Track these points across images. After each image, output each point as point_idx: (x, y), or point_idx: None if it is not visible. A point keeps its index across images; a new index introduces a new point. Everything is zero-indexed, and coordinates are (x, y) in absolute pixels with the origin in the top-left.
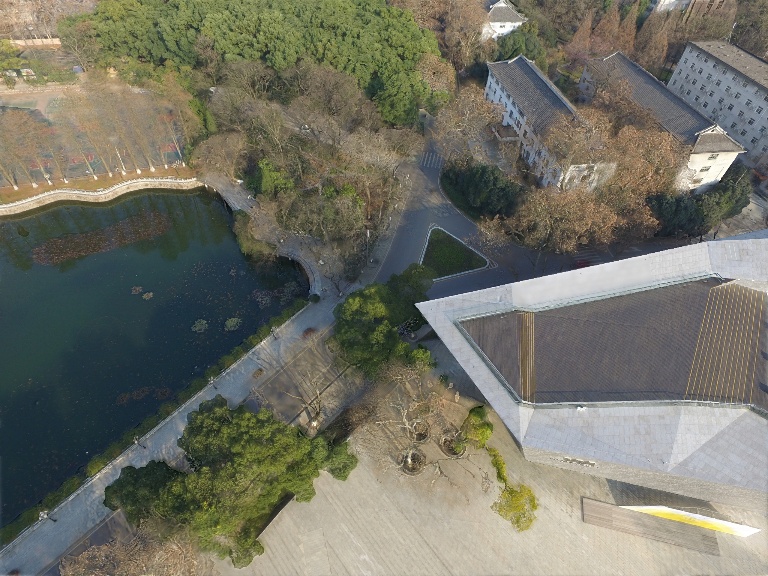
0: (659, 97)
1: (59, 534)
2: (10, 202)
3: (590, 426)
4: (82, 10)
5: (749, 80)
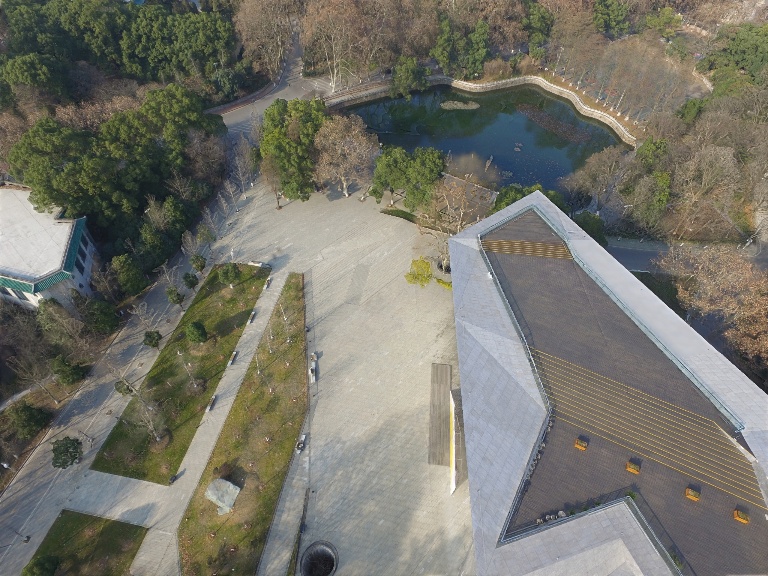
0: None
1: None
2: (551, 82)
3: (477, 279)
4: (758, 23)
5: None
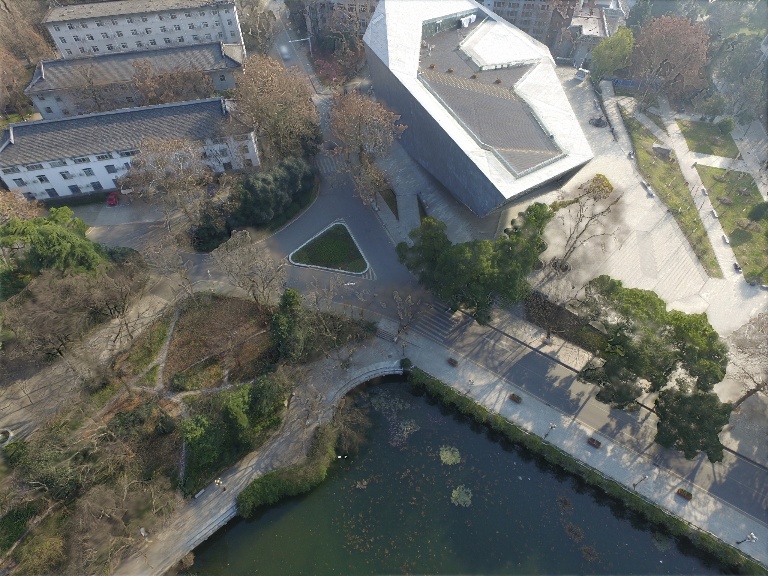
0: (152, 60)
1: (743, 532)
2: None
3: (562, 135)
4: None
5: (145, 14)
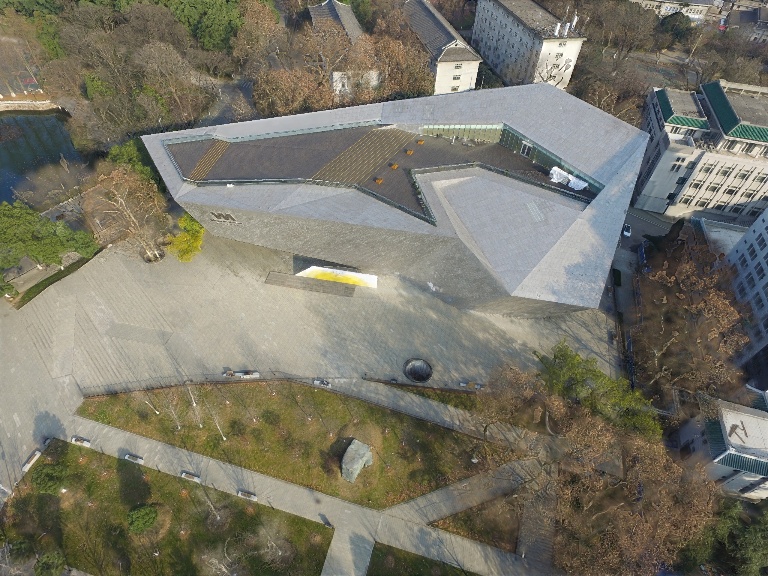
0: (431, 25)
1: None
2: None
3: (231, 194)
4: None
5: (508, 12)
